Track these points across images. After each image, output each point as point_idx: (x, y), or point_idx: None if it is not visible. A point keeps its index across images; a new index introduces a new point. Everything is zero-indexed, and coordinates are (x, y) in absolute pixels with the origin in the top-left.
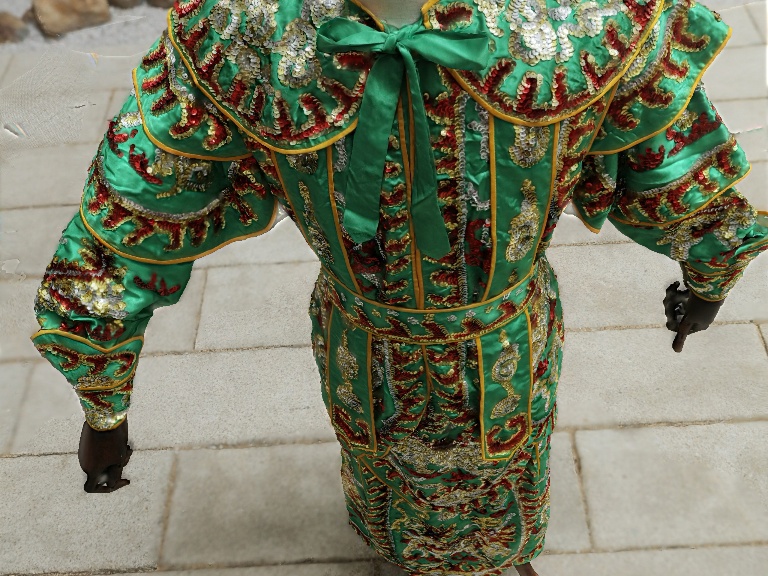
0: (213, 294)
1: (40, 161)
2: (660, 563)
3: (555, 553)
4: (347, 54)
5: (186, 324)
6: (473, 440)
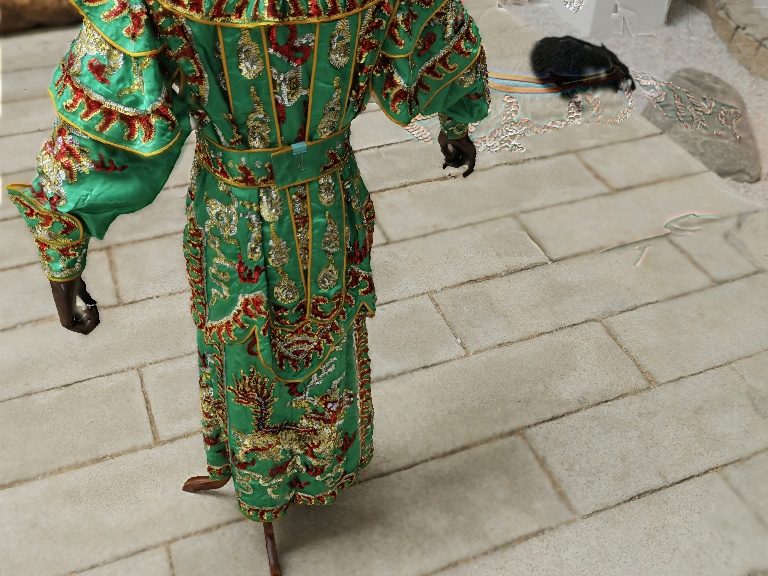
0: None
1: None
2: (107, 548)
3: (202, 532)
4: None
5: None
6: None
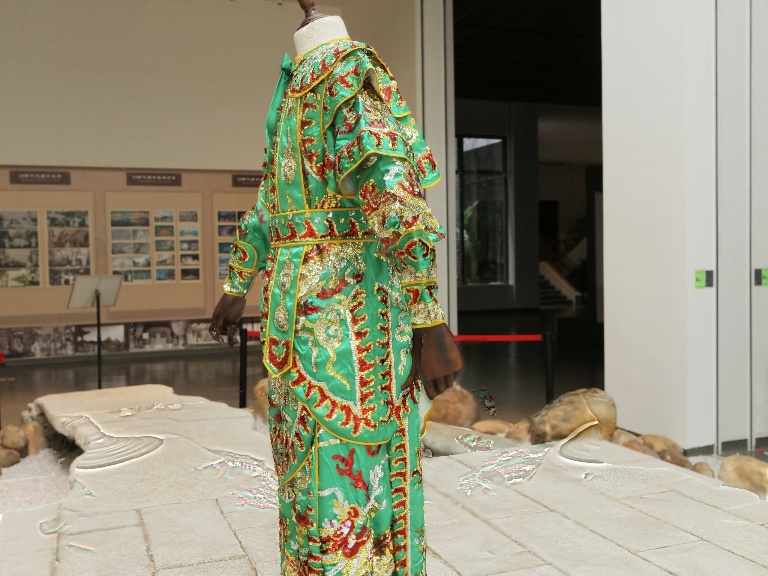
0: (526, 571)
1: (572, 489)
2: None
3: None
4: None
5: (487, 569)
6: None
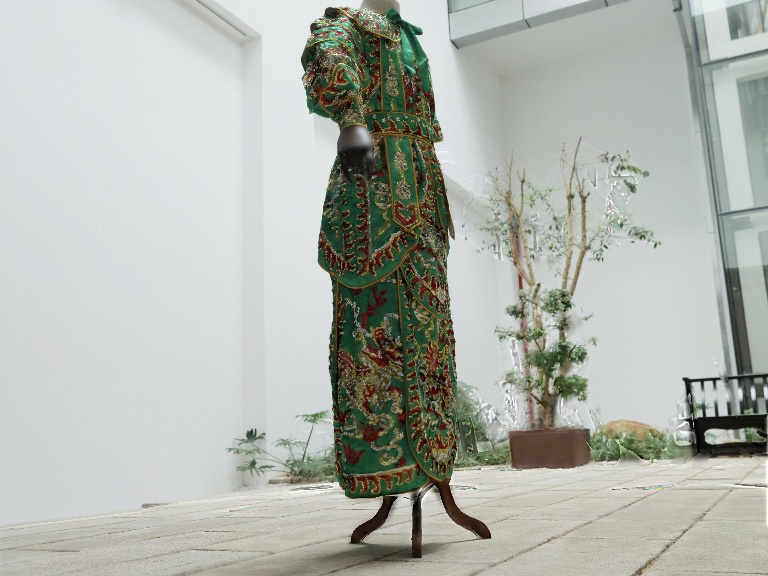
0: None
1: None
2: None
3: None
4: (392, 21)
5: None
6: (440, 230)
